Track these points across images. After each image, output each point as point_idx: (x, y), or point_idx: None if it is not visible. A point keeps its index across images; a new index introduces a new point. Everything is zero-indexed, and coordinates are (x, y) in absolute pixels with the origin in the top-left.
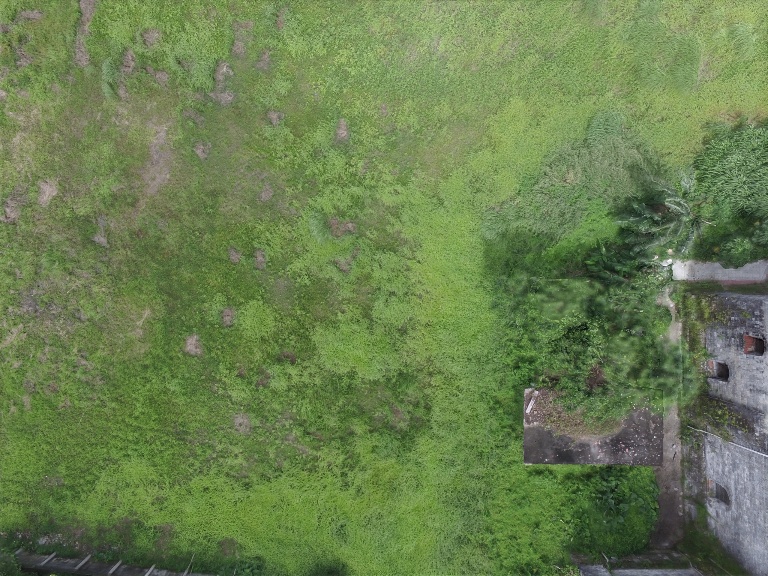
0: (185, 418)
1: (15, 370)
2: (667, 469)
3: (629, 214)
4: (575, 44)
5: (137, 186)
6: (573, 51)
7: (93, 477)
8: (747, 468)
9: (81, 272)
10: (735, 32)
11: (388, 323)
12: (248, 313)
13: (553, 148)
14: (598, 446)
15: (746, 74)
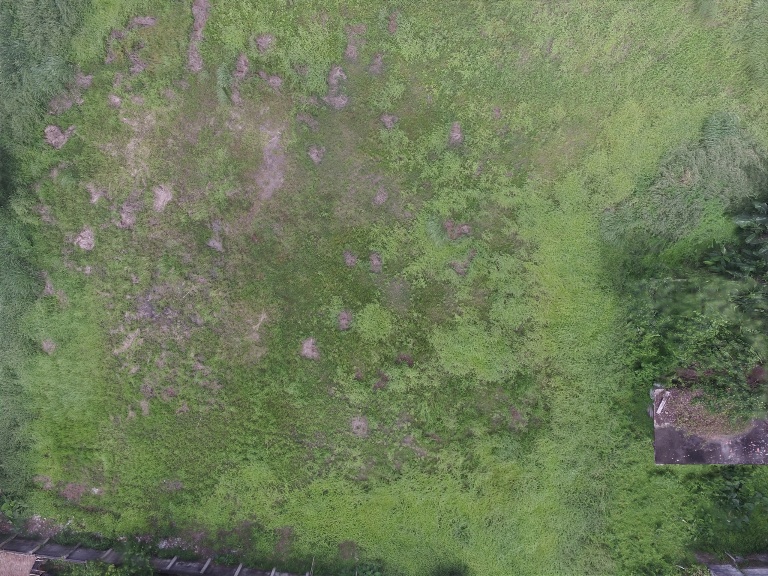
0: (303, 421)
1: (133, 375)
2: None
3: (749, 214)
4: (688, 45)
5: (251, 191)
6: (686, 52)
7: (212, 481)
8: None
9: (197, 277)
10: None
11: (506, 325)
12: (366, 316)
13: (669, 149)
14: (729, 446)
15: None
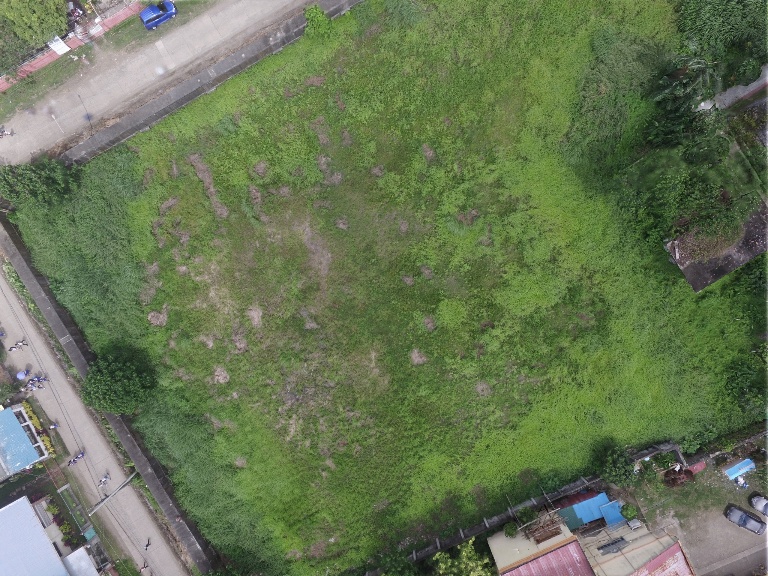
0: (443, 409)
1: (309, 448)
2: None
3: (658, 89)
4: None
5: (313, 274)
6: (550, 3)
7: (407, 486)
8: None
9: (312, 355)
10: None
11: (540, 261)
12: (443, 312)
13: (579, 77)
14: (737, 252)
15: None
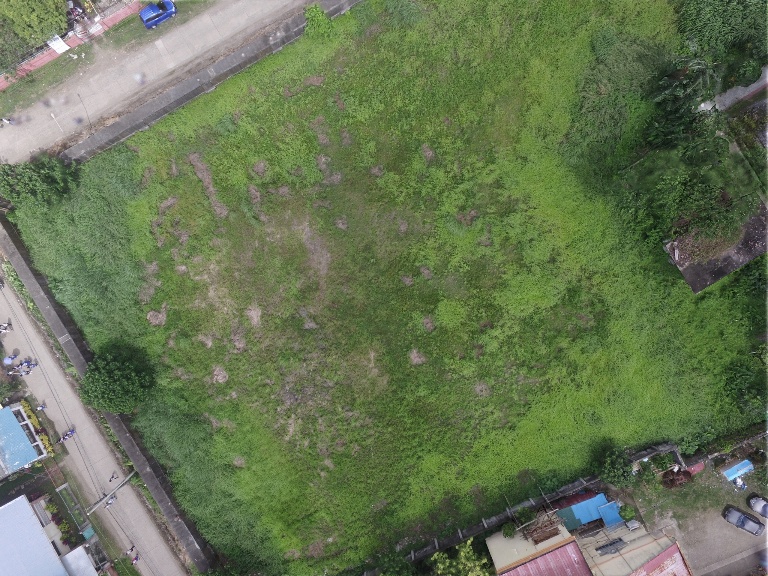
0: (442, 409)
1: (308, 447)
2: None
3: (658, 90)
4: None
5: (312, 274)
6: (551, 3)
7: (405, 486)
8: None
9: (311, 355)
10: None
11: (540, 262)
12: (442, 312)
13: (579, 77)
14: (736, 253)
15: None
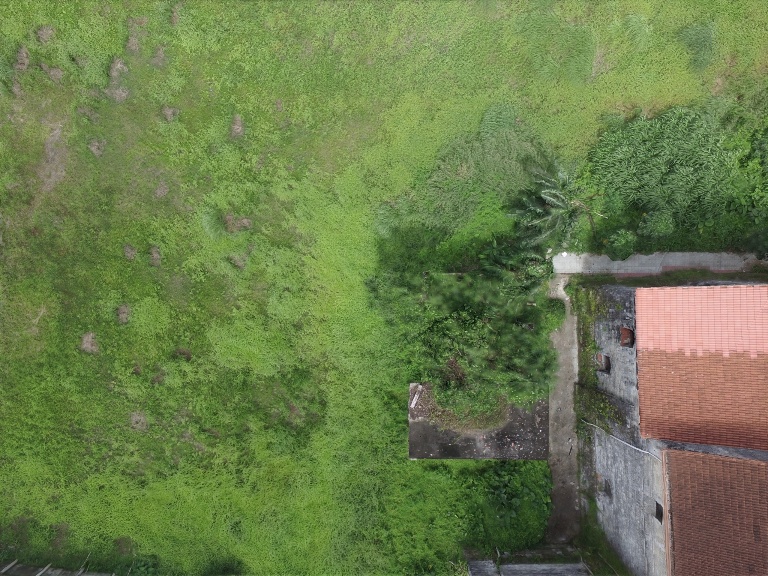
0: (81, 416)
1: None
2: (563, 463)
3: (521, 207)
4: (470, 37)
5: (32, 184)
6: (468, 44)
7: None
8: (623, 461)
9: None
10: (628, 23)
11: (283, 319)
12: (142, 310)
13: (446, 141)
14: (484, 440)
15: (641, 65)
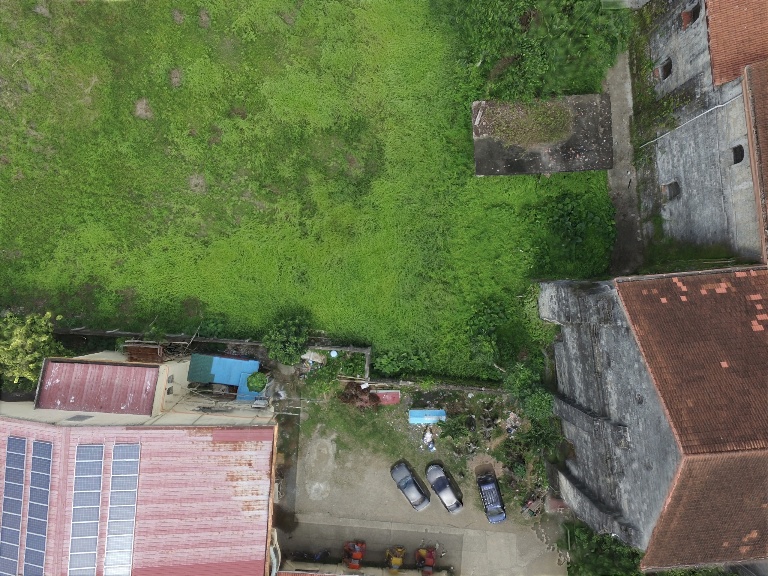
0: (140, 182)
1: None
2: (623, 197)
3: None
4: None
5: None
6: None
7: (51, 246)
8: (692, 141)
9: (25, 43)
10: None
11: (337, 71)
12: (195, 70)
13: None
14: (549, 154)
15: None
